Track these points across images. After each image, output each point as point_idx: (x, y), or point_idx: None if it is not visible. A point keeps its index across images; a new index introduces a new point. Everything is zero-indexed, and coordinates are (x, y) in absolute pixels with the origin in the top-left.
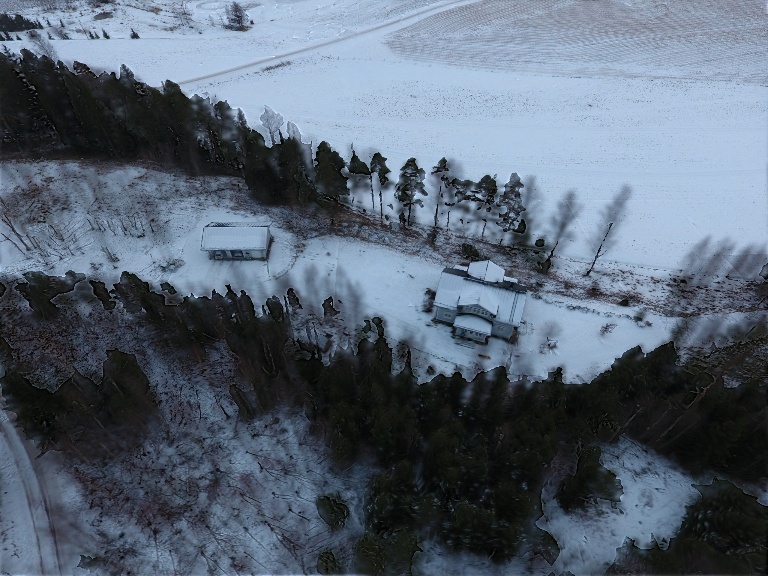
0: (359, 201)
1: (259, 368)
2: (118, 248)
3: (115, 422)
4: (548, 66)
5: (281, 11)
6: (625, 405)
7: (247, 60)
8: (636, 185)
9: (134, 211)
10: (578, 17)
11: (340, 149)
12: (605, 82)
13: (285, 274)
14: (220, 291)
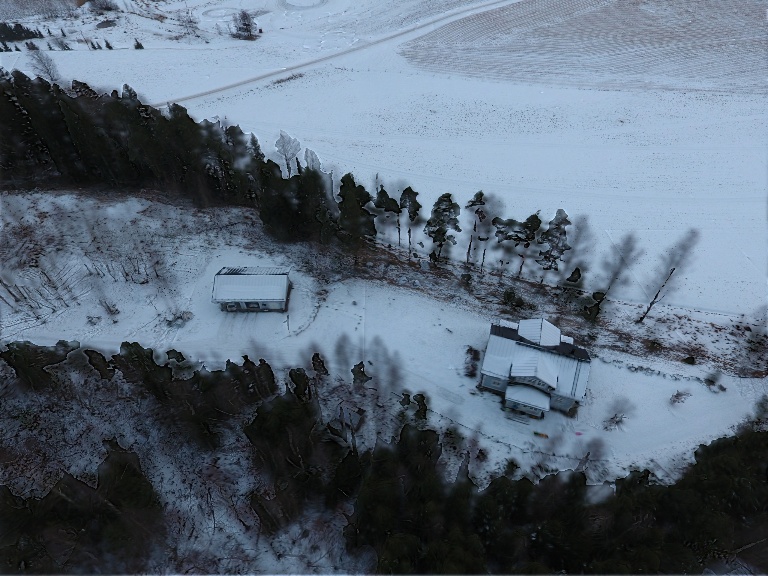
0: (382, 232)
1: (283, 459)
2: (118, 297)
3: (112, 535)
4: (573, 78)
5: (290, 19)
6: (724, 513)
7: (257, 72)
8: (681, 212)
9: (137, 252)
10: (601, 25)
11: (358, 171)
12: (635, 95)
13: (307, 328)
14: (234, 351)
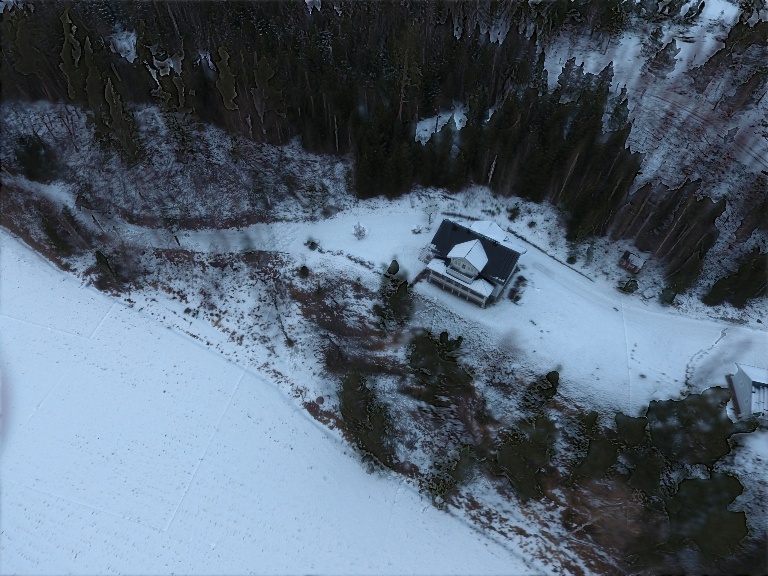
0: None
1: None
2: None
3: None
4: None
5: None
6: None
7: None
8: None
9: None
10: None
11: None
12: None
13: (693, 357)
14: (765, 342)
